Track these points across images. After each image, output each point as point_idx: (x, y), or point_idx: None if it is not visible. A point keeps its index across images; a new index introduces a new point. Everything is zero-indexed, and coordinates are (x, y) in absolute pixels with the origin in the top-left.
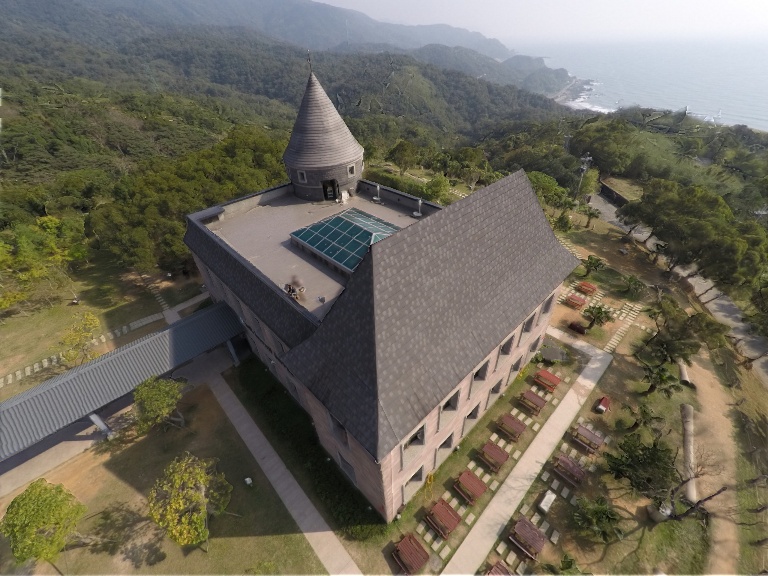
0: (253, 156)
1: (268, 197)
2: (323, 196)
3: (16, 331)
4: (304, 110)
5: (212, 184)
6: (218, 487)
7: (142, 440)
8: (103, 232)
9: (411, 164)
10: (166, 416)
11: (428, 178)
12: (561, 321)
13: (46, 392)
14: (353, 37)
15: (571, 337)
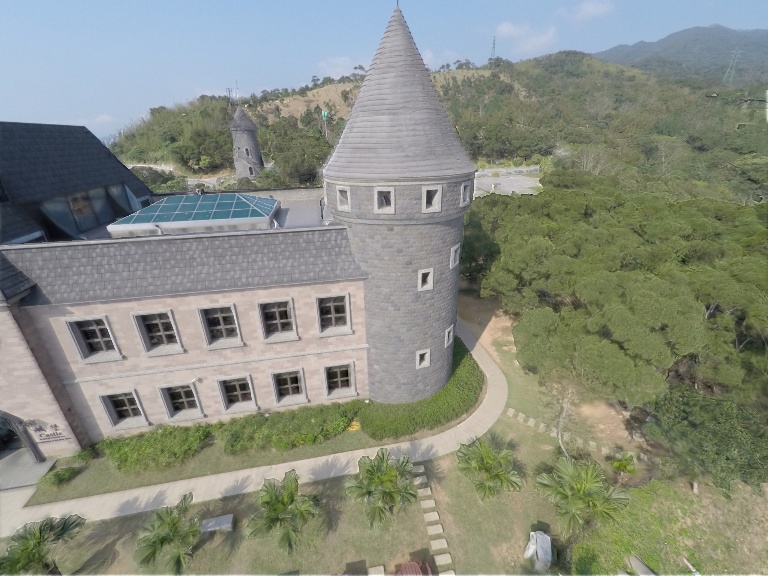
0: (734, 236)
1: None
2: None
3: None
4: None
5: None
6: None
7: None
8: None
9: None
10: None
11: None
12: None
13: None
14: None
15: None
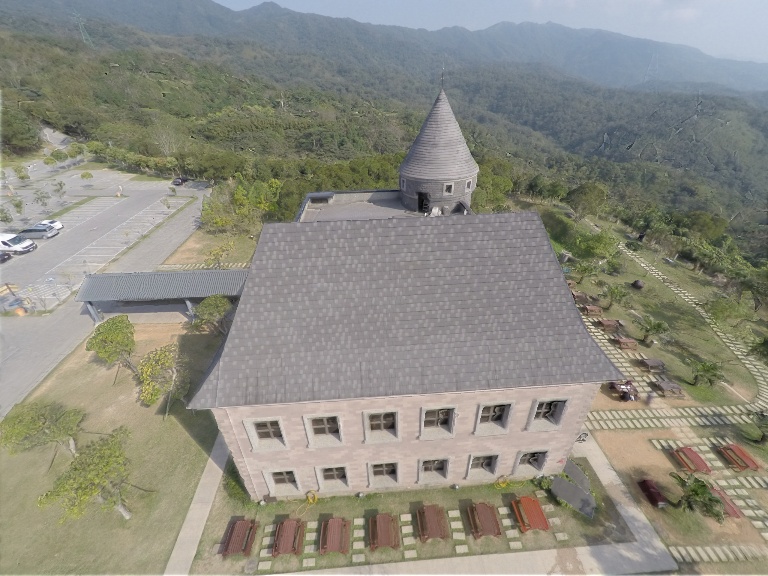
0: None
1: (379, 197)
2: (417, 207)
3: (218, 242)
4: (426, 124)
5: (369, 180)
6: (182, 380)
7: (204, 334)
8: (283, 195)
9: (593, 212)
10: (215, 324)
11: None
12: (635, 469)
13: (174, 274)
14: (655, 73)
15: (627, 495)
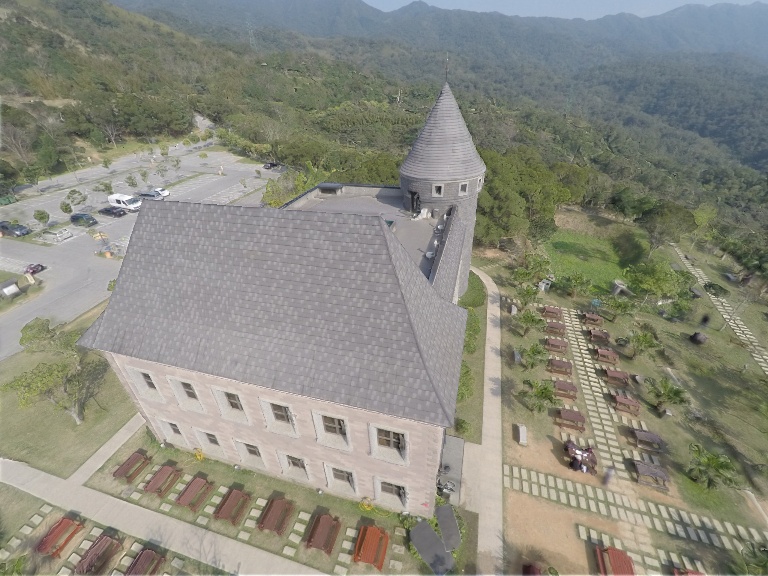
0: None
1: (387, 193)
2: (411, 207)
3: None
4: None
5: None
6: None
7: None
8: None
9: (676, 239)
10: None
11: (709, 272)
12: (532, 549)
13: None
14: None
15: (498, 573)
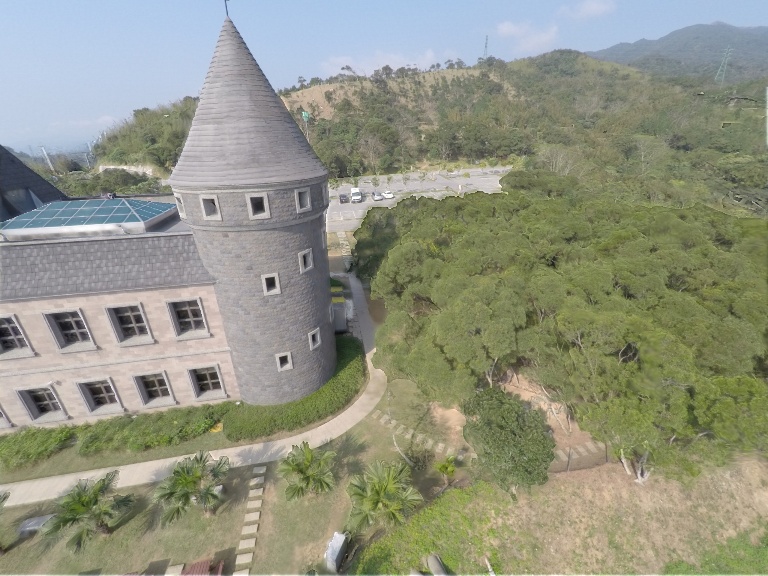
0: None
1: None
2: None
3: None
4: None
5: None
6: None
7: None
8: None
9: None
10: None
11: None
12: None
13: None
14: None
15: None
